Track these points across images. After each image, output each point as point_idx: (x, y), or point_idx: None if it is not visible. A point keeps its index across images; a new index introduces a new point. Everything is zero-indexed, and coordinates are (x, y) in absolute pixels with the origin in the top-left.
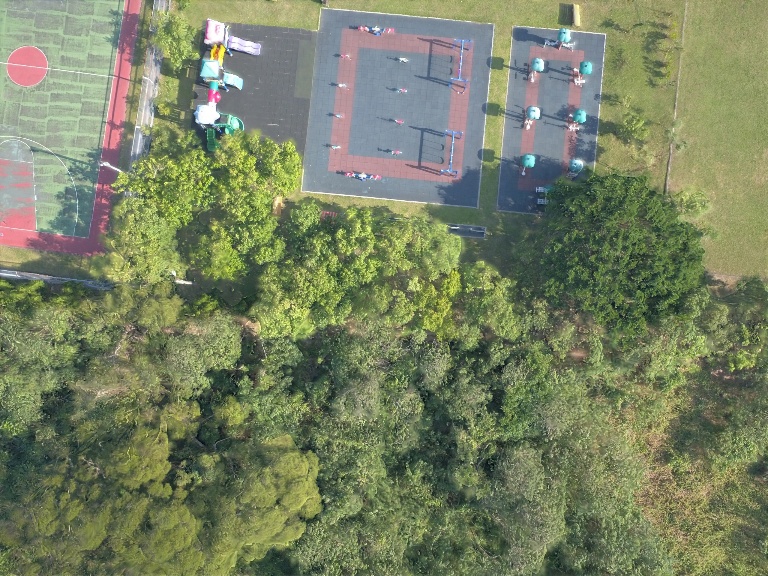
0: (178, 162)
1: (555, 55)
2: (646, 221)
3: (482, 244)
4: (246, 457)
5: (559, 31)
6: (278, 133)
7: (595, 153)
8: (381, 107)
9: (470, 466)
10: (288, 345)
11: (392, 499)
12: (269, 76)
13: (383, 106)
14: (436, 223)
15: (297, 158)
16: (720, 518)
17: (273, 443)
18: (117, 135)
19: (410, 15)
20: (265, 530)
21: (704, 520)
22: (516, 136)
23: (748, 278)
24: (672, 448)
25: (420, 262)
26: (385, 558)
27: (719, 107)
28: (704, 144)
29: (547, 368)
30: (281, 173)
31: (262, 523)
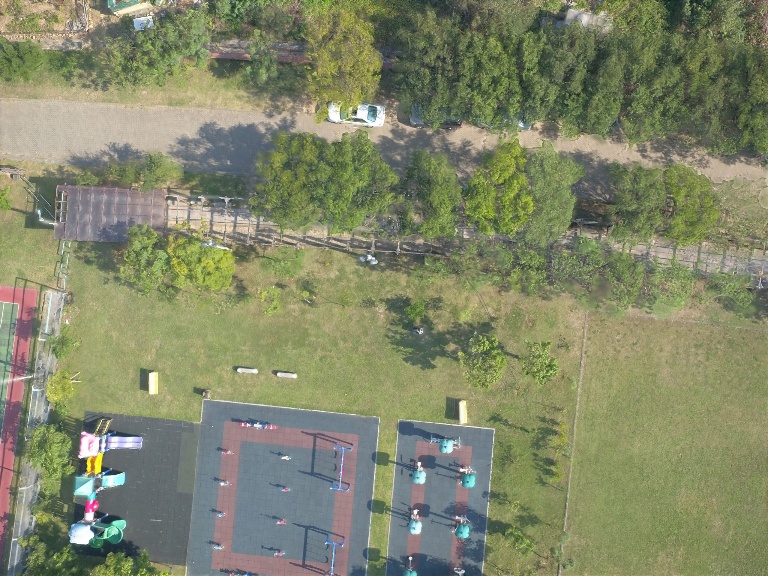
0: None
1: None
2: None
3: None
4: None
5: (440, 443)
6: (161, 529)
7: (484, 553)
8: (264, 503)
9: None
10: None
11: None
12: (151, 470)
13: (266, 502)
14: None
15: None
16: None
17: None
18: (1, 527)
19: (294, 408)
20: None
21: None
22: (402, 535)
23: None
24: None
25: None
26: None
27: (612, 507)
28: (596, 545)
29: None
30: None
31: None
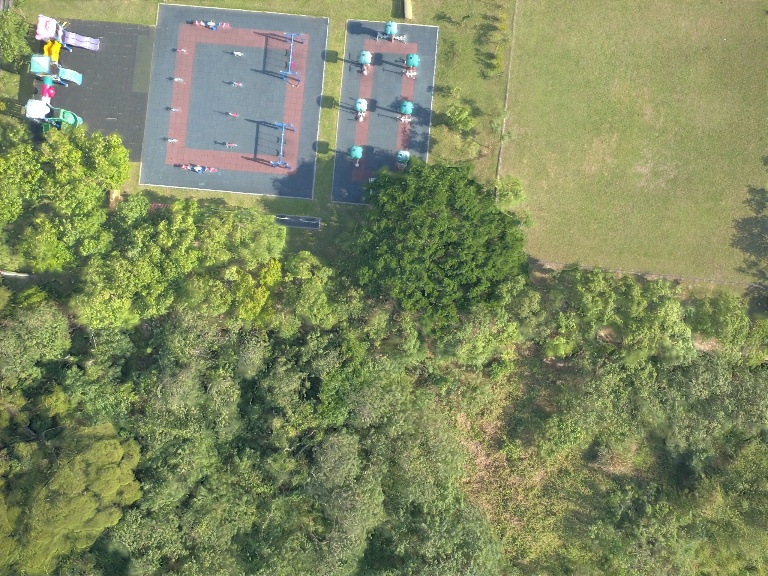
0: (7, 156)
1: (388, 48)
2: (457, 210)
3: (317, 235)
4: (72, 445)
5: (385, 24)
6: (117, 127)
7: (428, 144)
8: (217, 100)
9: (284, 452)
10: (116, 335)
11: (217, 486)
12: (108, 71)
13: (219, 99)
14: (271, 214)
15: (123, 151)
16: (552, 503)
17: (89, 430)
18: None
19: (246, 10)
20: (74, 515)
21: (537, 506)
22: (350, 128)
23: (578, 266)
24: (505, 435)
25: (239, 252)
26: (208, 544)
27: (549, 98)
28: (535, 134)
29: (362, 355)
30: (105, 166)
31: (70, 508)
